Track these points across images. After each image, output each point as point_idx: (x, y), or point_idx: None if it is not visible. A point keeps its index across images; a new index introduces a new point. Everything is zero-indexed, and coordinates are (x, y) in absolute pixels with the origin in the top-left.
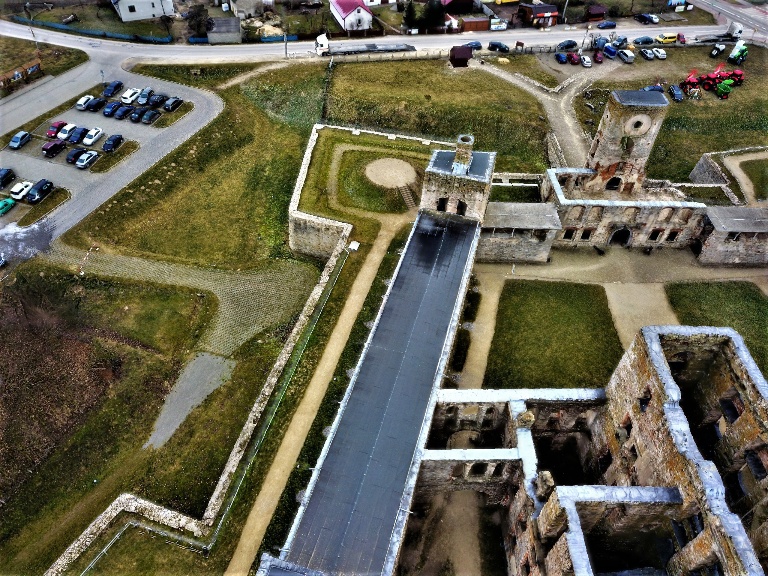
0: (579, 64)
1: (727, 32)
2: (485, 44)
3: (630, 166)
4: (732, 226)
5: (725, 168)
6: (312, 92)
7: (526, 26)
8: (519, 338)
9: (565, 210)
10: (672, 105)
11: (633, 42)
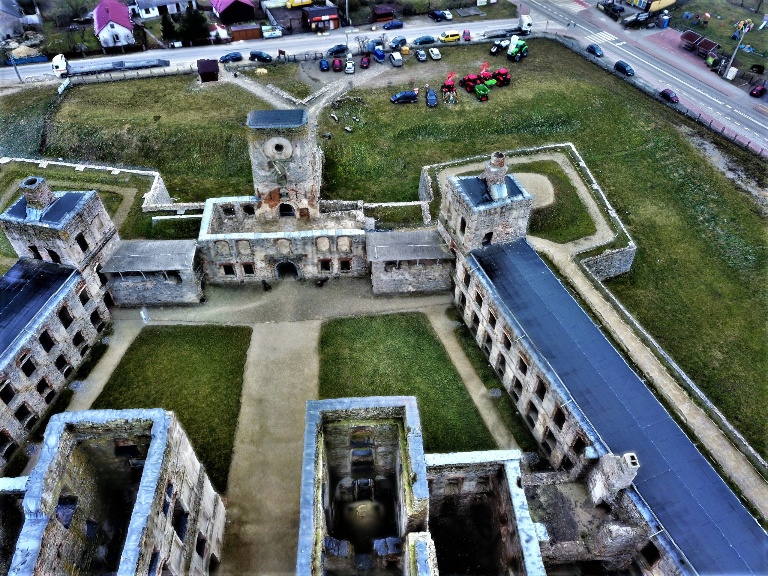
0: (342, 71)
1: (518, 26)
2: (249, 54)
3: (293, 191)
4: (386, 254)
5: (436, 182)
6: (32, 119)
7: (305, 31)
8: (127, 396)
9: (207, 246)
10: (424, 111)
11: (413, 42)
